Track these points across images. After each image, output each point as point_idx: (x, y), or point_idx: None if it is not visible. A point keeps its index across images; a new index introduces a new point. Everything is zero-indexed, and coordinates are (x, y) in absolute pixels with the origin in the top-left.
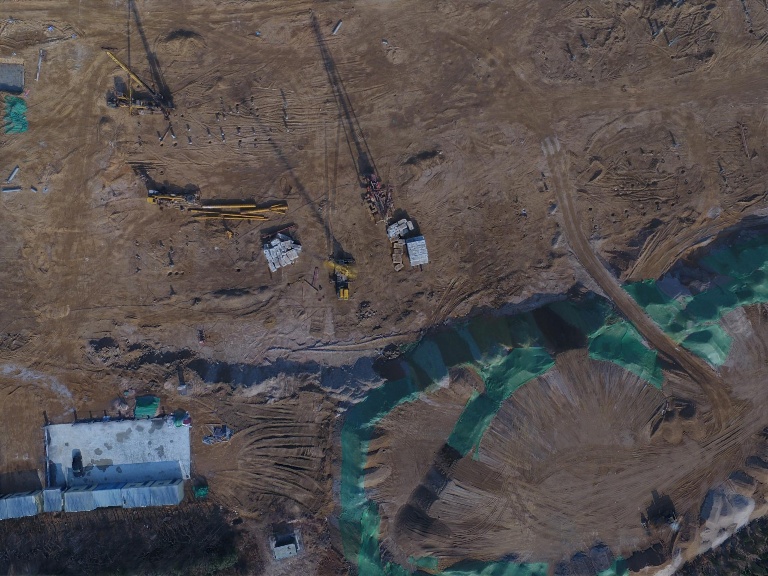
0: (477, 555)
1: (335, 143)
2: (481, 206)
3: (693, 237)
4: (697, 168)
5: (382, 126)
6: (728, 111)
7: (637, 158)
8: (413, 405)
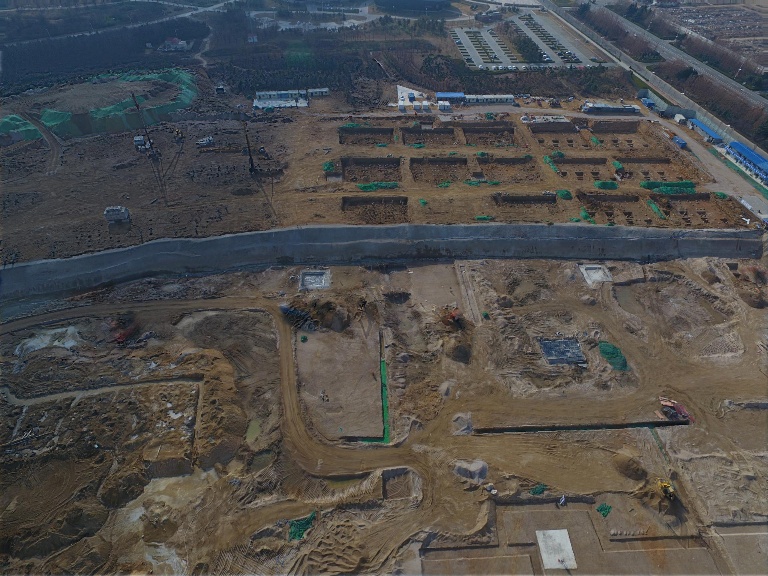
0: None
1: None
2: None
3: None
4: None
5: None
6: None
7: (4, 172)
8: None
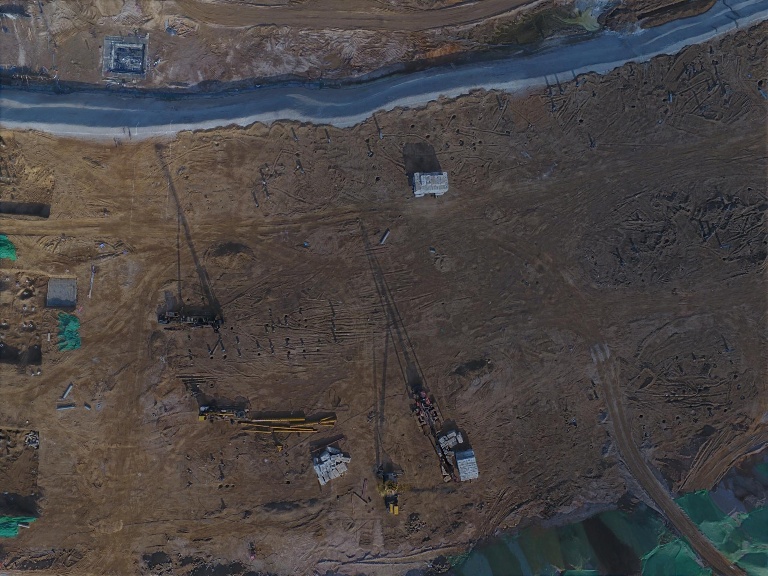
0: None
1: (383, 353)
2: (530, 416)
3: (746, 444)
4: (750, 373)
5: (430, 335)
6: None
7: (688, 363)
8: None
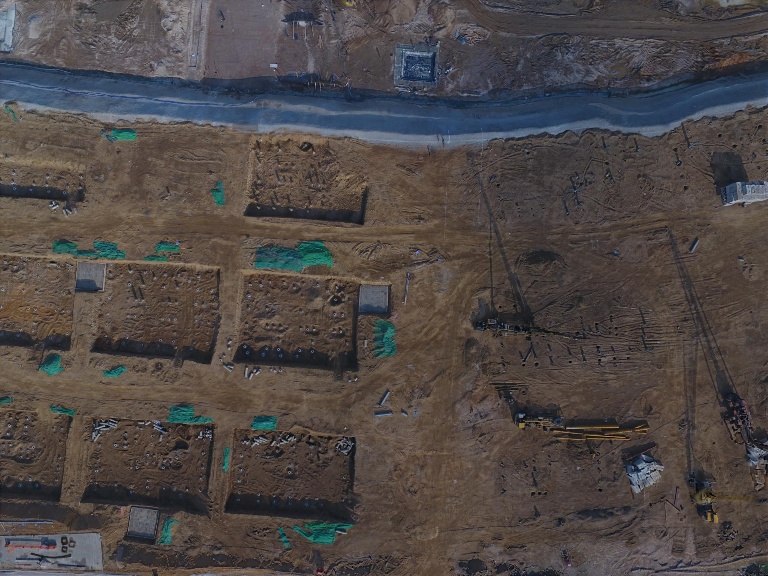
0: None
1: (693, 361)
2: None
3: None
4: None
5: (739, 344)
6: None
7: None
8: None
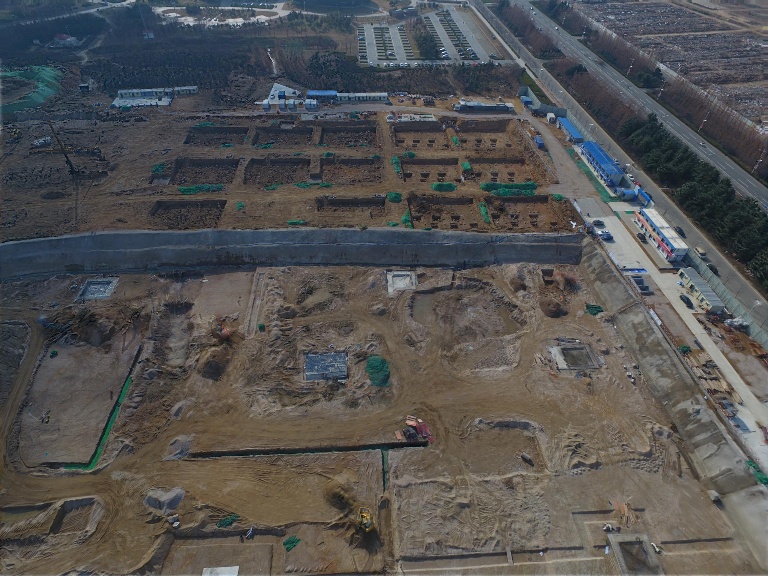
0: (0, 79)
1: None
2: None
3: None
4: None
5: None
6: None
7: None
8: (2, 104)
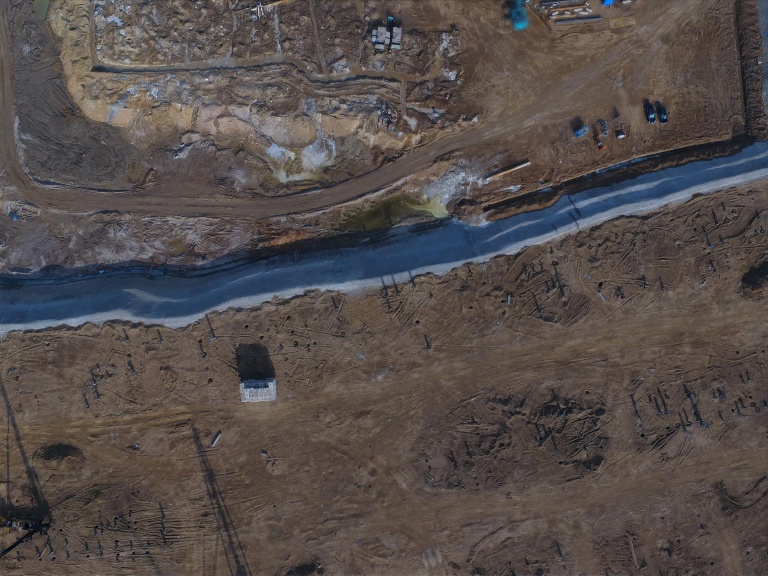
0: None
1: (213, 556)
2: None
3: None
4: None
5: (261, 538)
6: (617, 519)
7: (521, 569)
8: None
